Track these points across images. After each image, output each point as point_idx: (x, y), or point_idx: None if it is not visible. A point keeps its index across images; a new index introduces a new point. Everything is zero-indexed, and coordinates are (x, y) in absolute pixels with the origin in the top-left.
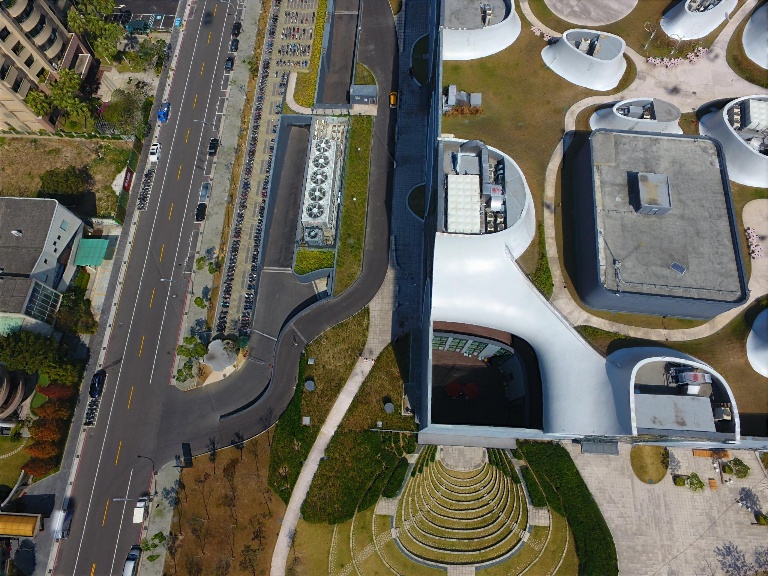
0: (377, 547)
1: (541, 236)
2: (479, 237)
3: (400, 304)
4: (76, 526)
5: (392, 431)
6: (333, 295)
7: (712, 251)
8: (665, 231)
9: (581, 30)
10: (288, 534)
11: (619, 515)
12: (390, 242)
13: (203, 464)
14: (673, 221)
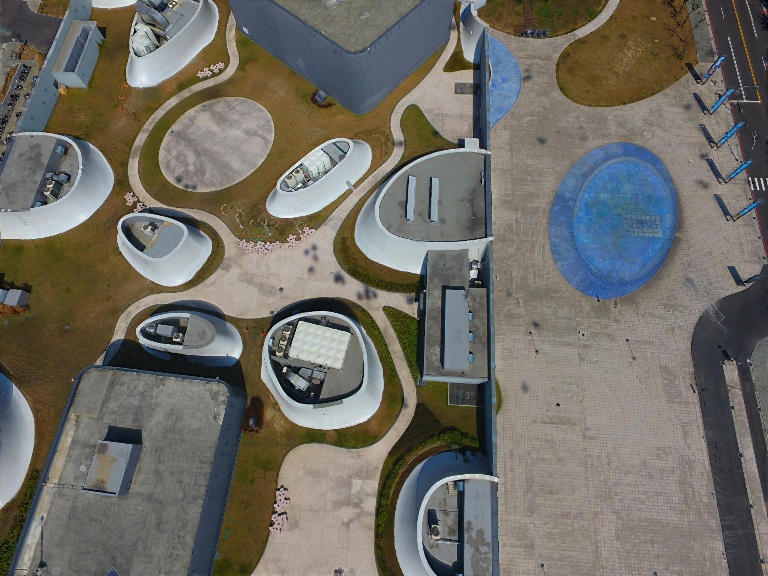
0: None
1: (27, 493)
2: None
3: None
4: None
5: None
6: None
7: (165, 552)
8: (120, 519)
9: (143, 214)
10: None
11: None
12: None
13: None
14: (135, 504)
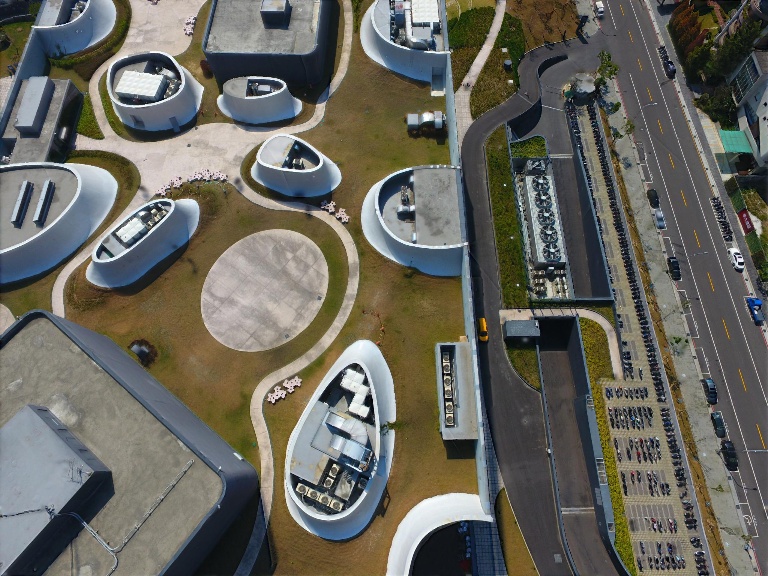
0: None
1: (357, 21)
2: None
3: None
4: (637, 4)
5: None
6: None
7: None
8: None
9: (302, 171)
10: (500, 3)
11: None
12: (462, 171)
13: (569, 34)
14: None
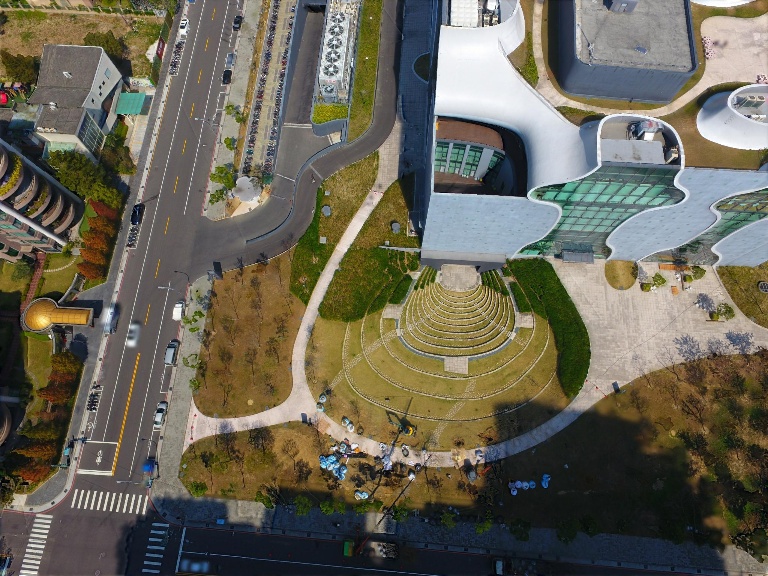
0: (384, 342)
1: (529, 41)
2: (477, 29)
3: (406, 149)
4: (122, 325)
5: (398, 250)
6: (347, 141)
7: (670, 38)
8: (632, 24)
9: None
10: (307, 329)
11: (593, 313)
12: (398, 100)
13: (232, 277)
14: (639, 17)
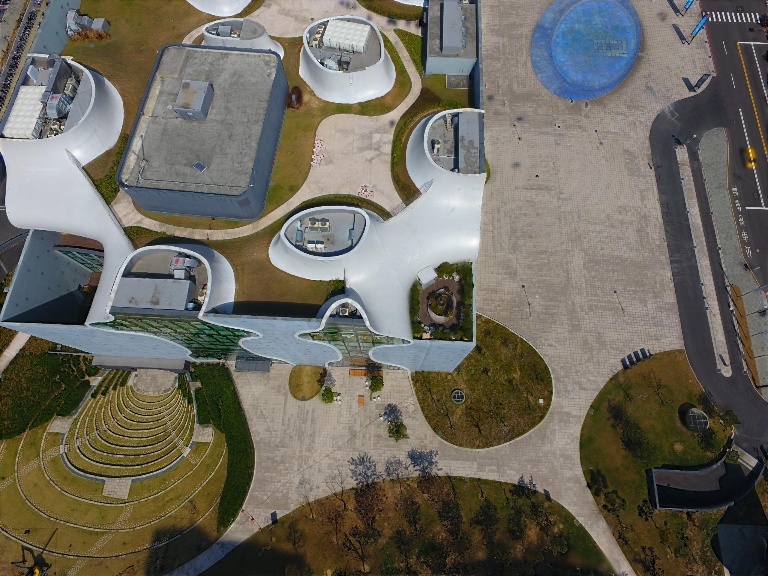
0: (42, 461)
1: (121, 147)
2: (31, 141)
3: None
4: None
5: (72, 354)
6: None
7: (237, 152)
8: (201, 134)
9: None
10: None
11: (266, 429)
12: None
13: None
14: (212, 126)
